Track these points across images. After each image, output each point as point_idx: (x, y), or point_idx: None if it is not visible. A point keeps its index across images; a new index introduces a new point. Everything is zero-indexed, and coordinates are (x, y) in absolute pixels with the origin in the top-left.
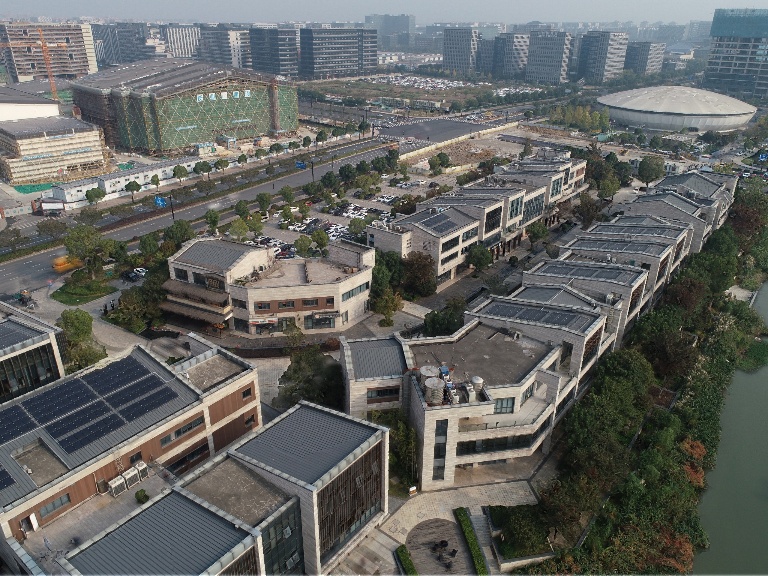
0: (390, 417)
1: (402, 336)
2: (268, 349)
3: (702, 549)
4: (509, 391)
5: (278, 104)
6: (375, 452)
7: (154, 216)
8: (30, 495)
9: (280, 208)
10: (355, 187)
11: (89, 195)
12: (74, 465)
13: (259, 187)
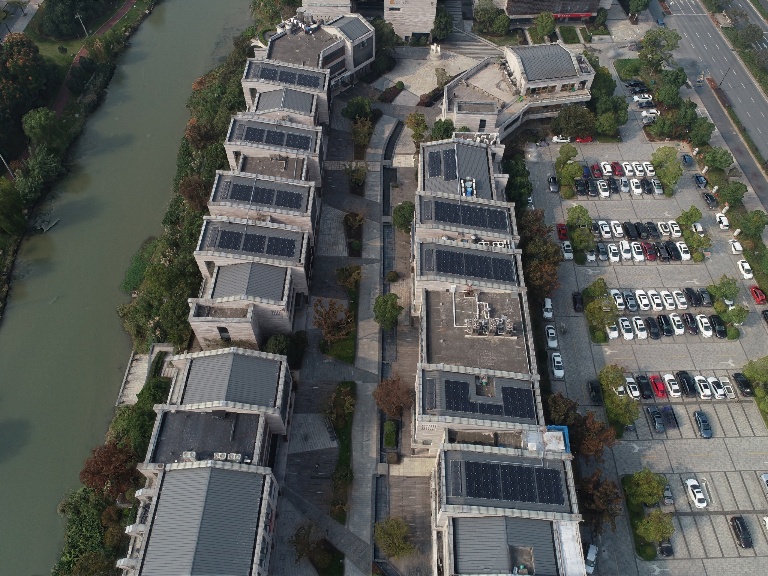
0: None
1: (379, 101)
2: None
3: None
4: None
5: None
6: None
7: None
8: None
9: (761, 261)
10: None
11: None
12: None
13: None
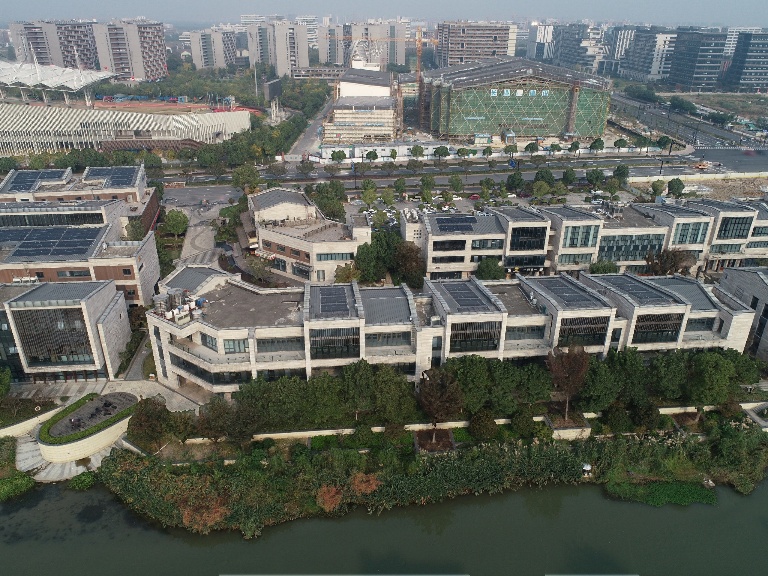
0: None
1: None
2: None
3: (241, 536)
4: (211, 331)
5: (577, 107)
6: (77, 313)
7: (357, 179)
8: None
9: None
10: (532, 192)
11: (333, 155)
12: (6, 261)
13: (469, 176)
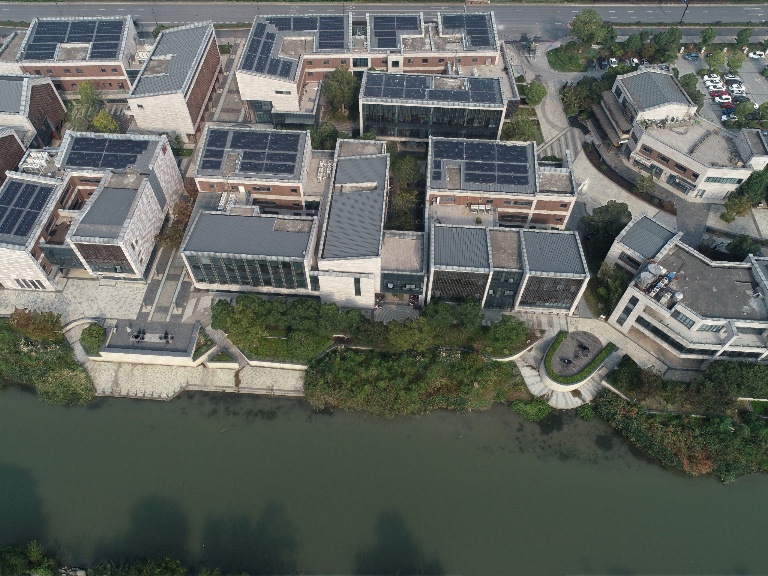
0: (619, 274)
1: (711, 236)
2: (628, 180)
3: (720, 481)
4: (693, 316)
5: None
6: (577, 282)
7: (675, 3)
8: (441, 190)
9: None
10: None
11: None
12: (464, 188)
13: None
